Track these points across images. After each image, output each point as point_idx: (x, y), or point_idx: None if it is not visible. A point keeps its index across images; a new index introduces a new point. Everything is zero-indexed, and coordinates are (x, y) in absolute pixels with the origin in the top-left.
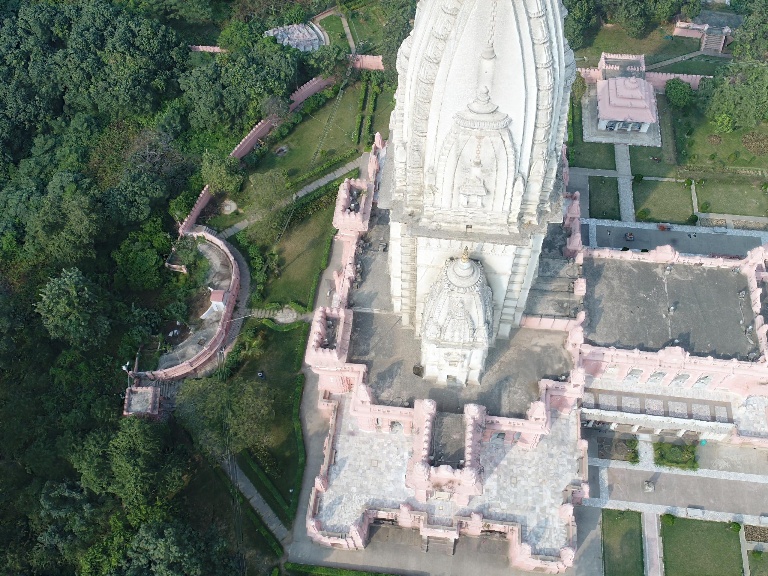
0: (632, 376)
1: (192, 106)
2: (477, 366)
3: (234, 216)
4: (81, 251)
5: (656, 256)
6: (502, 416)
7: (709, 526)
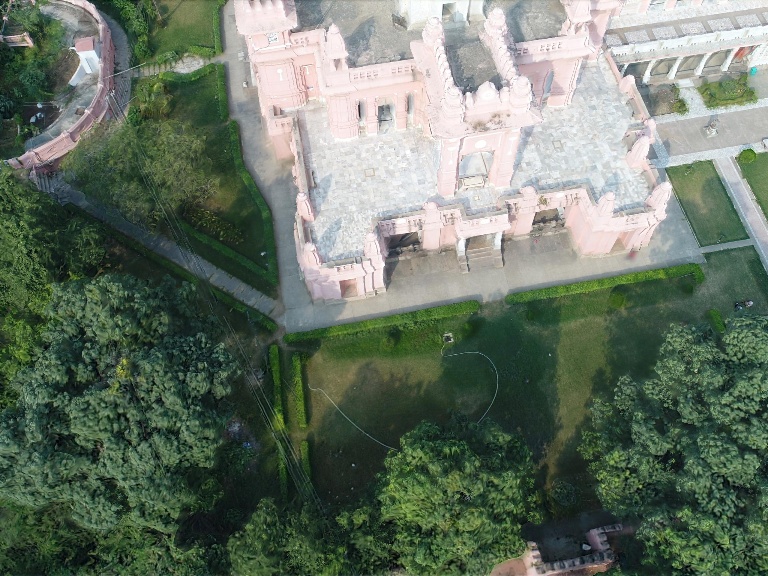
0: (655, 5)
1: None
2: None
3: None
4: None
5: None
6: None
7: None
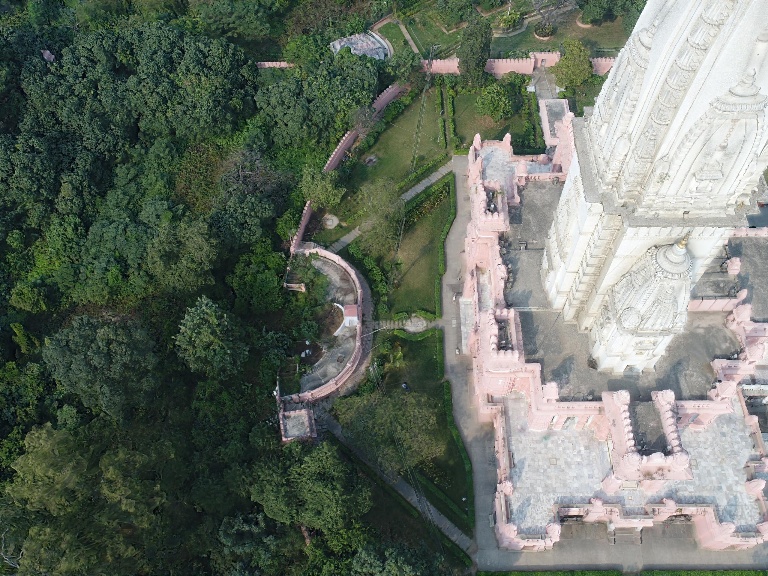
0: None
1: (272, 123)
2: (661, 352)
3: (339, 230)
4: (202, 278)
5: None
6: (685, 400)
7: None
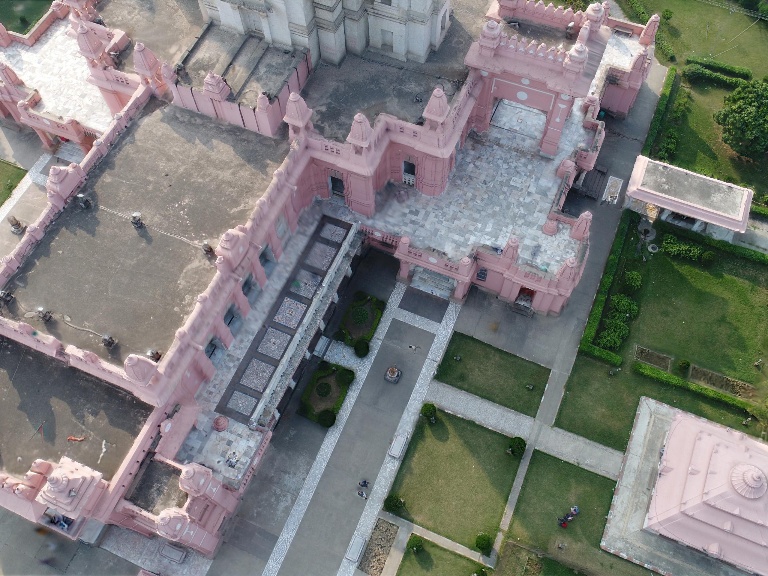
0: None
1: None
2: None
3: None
4: None
5: None
6: None
7: None
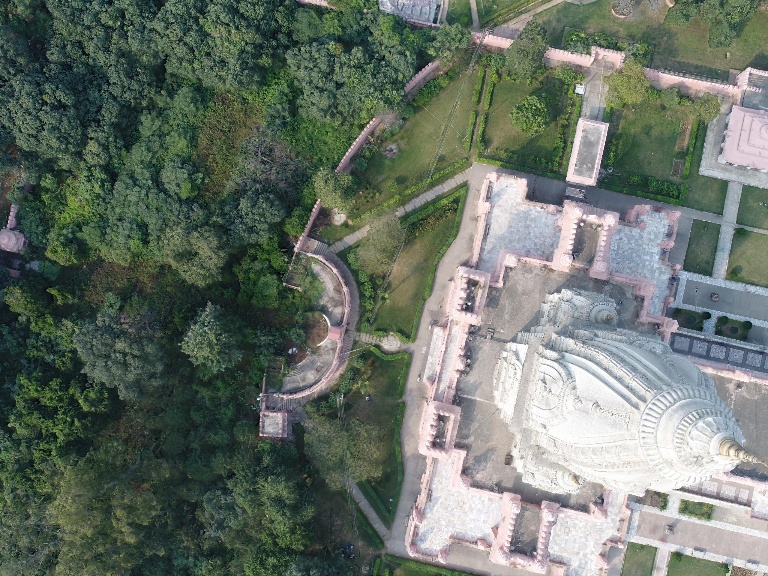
0: None
1: (300, 86)
2: None
3: (344, 230)
4: (210, 279)
5: (733, 378)
6: (570, 505)
7: (706, 563)
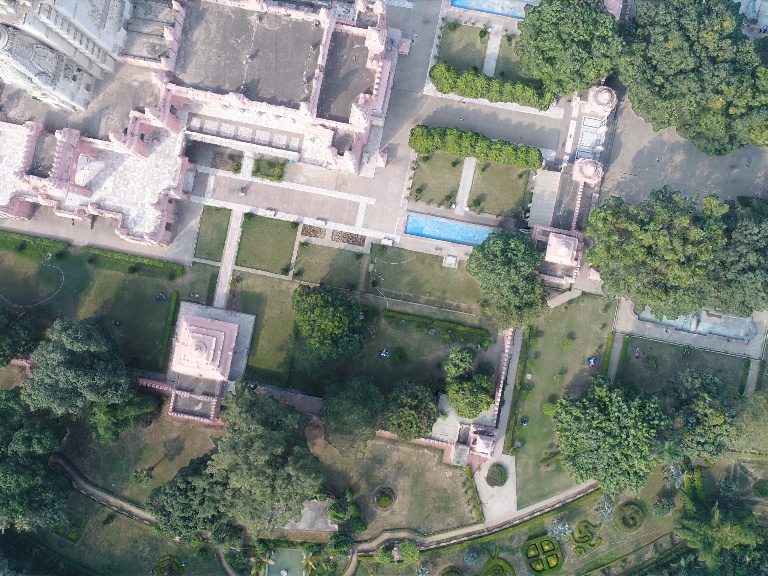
0: None
1: None
2: (67, 100)
3: None
4: None
5: (248, 5)
6: (99, 138)
7: (278, 223)
